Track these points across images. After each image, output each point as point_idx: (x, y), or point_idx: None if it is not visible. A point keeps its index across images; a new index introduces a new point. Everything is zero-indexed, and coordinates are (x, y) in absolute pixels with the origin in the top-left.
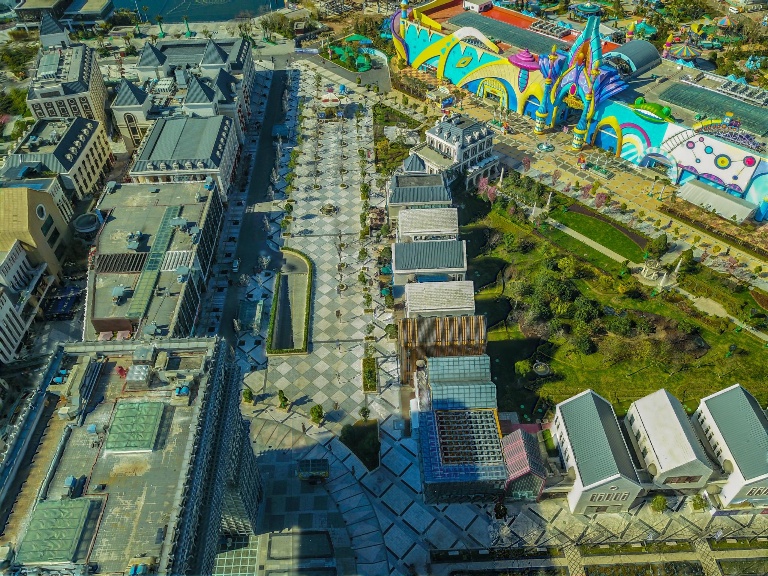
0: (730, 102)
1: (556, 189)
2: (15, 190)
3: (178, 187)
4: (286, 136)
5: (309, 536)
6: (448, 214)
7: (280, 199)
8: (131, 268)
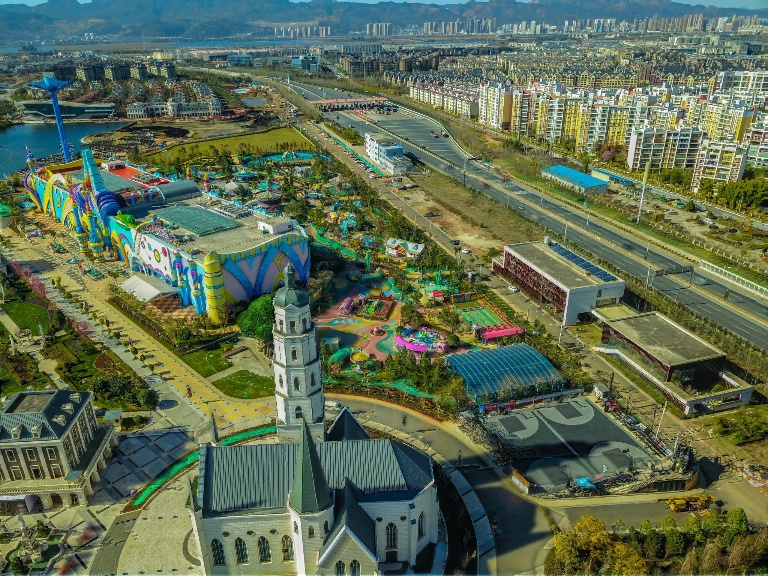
0: (205, 215)
1: None
2: None
3: None
4: None
5: None
6: None
7: None
8: None
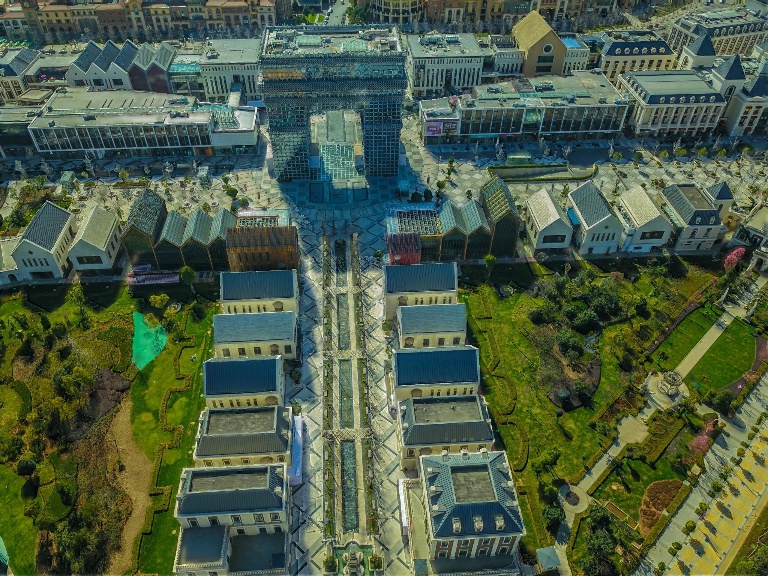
0: None
1: None
2: (548, 27)
3: (612, 93)
4: (756, 151)
5: (365, 193)
6: (651, 212)
7: (660, 160)
8: (520, 90)
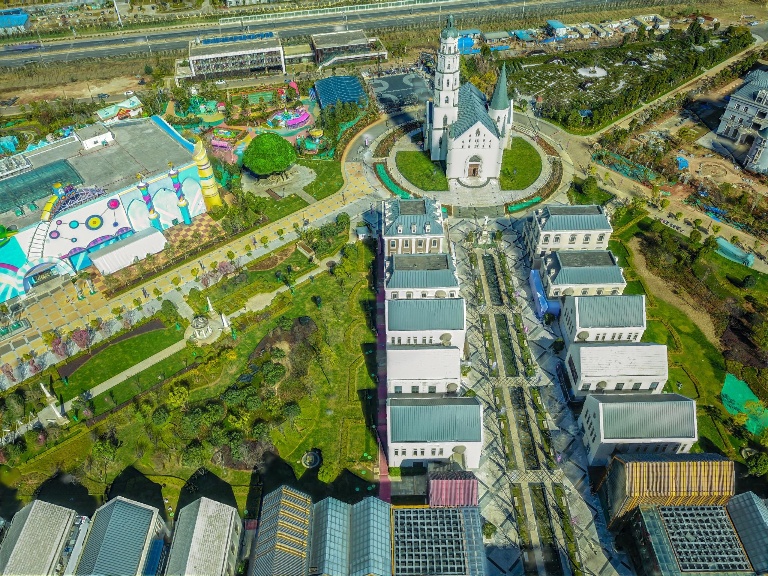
0: (12, 183)
1: (16, 383)
2: None
3: None
4: None
5: None
6: (40, 516)
7: None
8: None
